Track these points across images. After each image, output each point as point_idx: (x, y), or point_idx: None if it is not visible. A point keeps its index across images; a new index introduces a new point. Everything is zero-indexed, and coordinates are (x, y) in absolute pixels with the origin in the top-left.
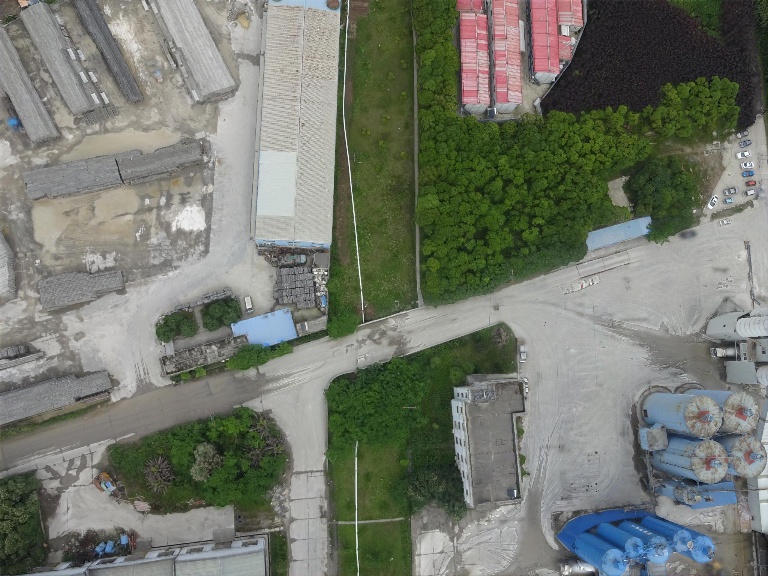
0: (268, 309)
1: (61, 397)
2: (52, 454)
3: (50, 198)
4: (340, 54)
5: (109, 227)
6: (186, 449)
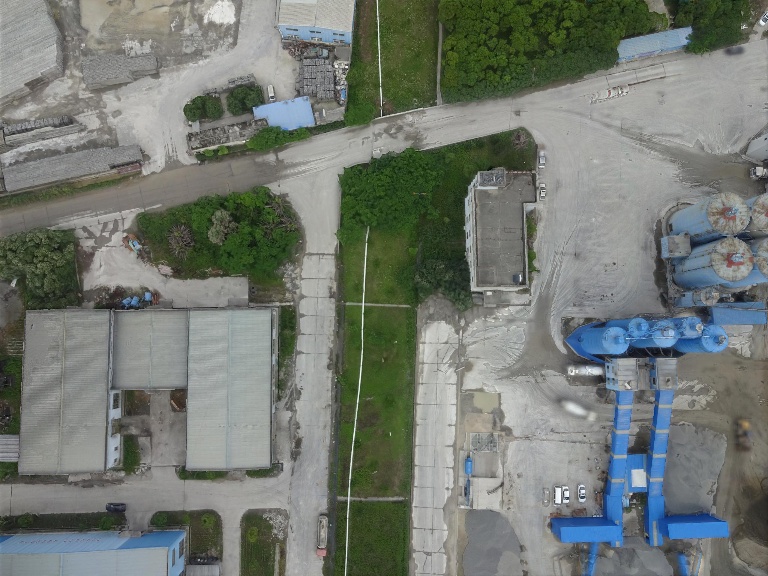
0: None
1: (97, 163)
2: (89, 216)
3: None
4: None
5: (147, 17)
6: (205, 215)
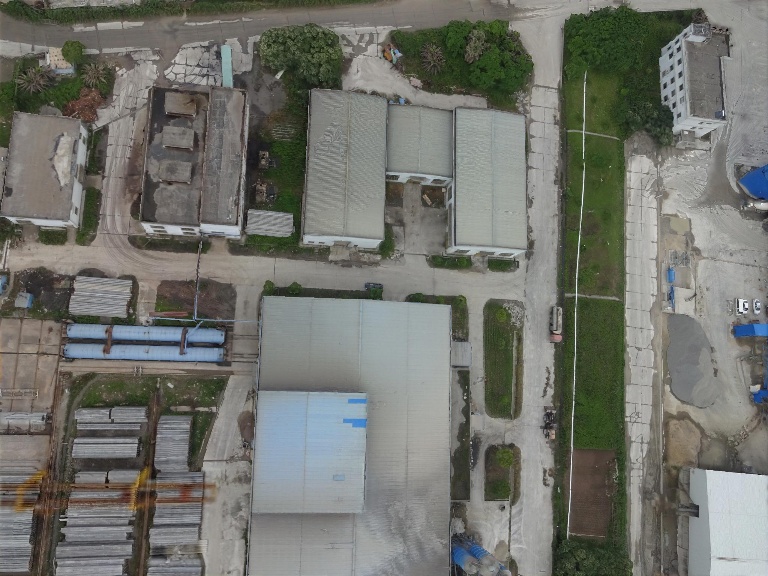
0: None
1: None
2: (347, 27)
3: None
4: None
5: None
6: (461, 34)
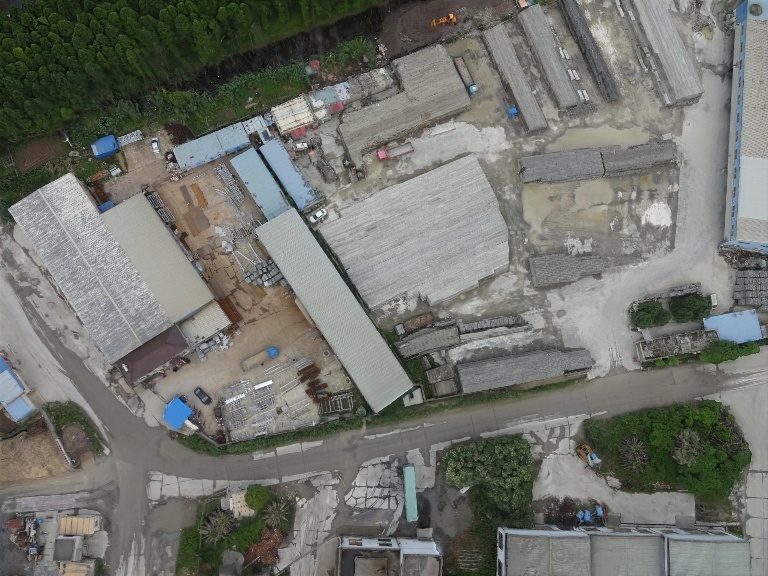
0: (727, 308)
1: (553, 368)
2: (536, 421)
3: (539, 183)
4: None
5: (587, 215)
6: (668, 433)
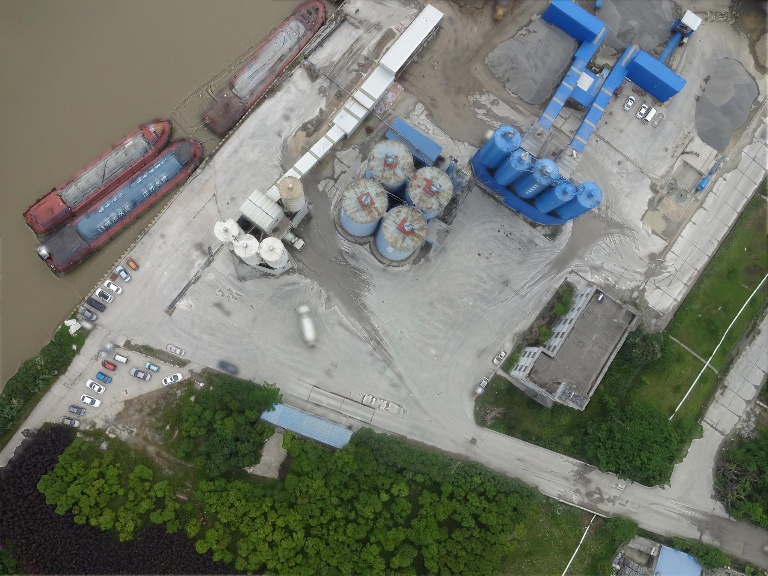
0: None
1: None
2: None
3: None
4: None
5: None
6: None
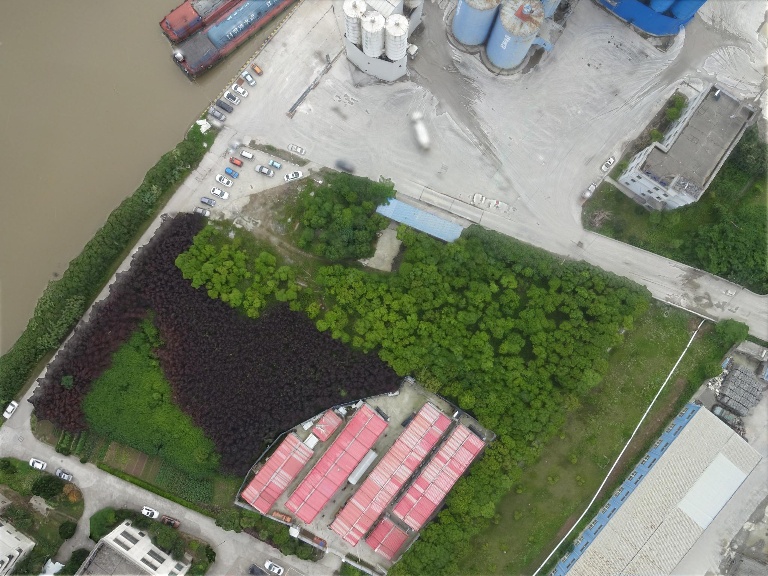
0: None
1: None
2: None
3: None
4: (550, 569)
5: None
6: None
